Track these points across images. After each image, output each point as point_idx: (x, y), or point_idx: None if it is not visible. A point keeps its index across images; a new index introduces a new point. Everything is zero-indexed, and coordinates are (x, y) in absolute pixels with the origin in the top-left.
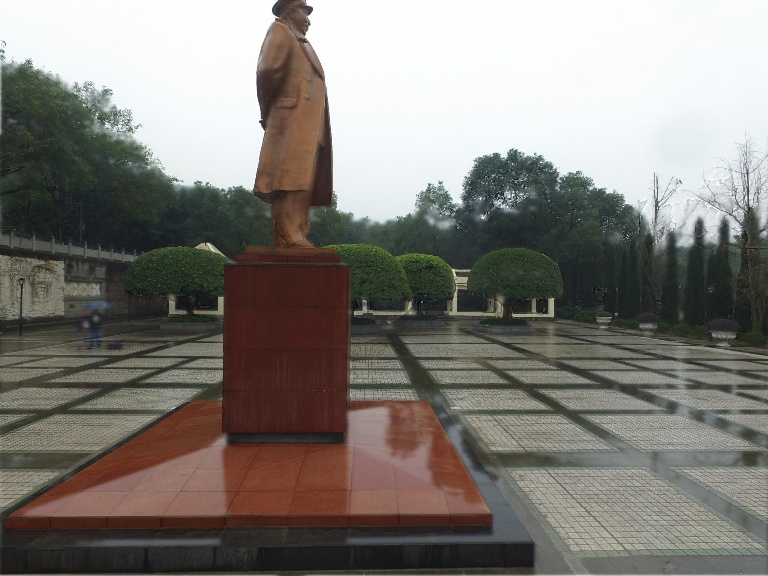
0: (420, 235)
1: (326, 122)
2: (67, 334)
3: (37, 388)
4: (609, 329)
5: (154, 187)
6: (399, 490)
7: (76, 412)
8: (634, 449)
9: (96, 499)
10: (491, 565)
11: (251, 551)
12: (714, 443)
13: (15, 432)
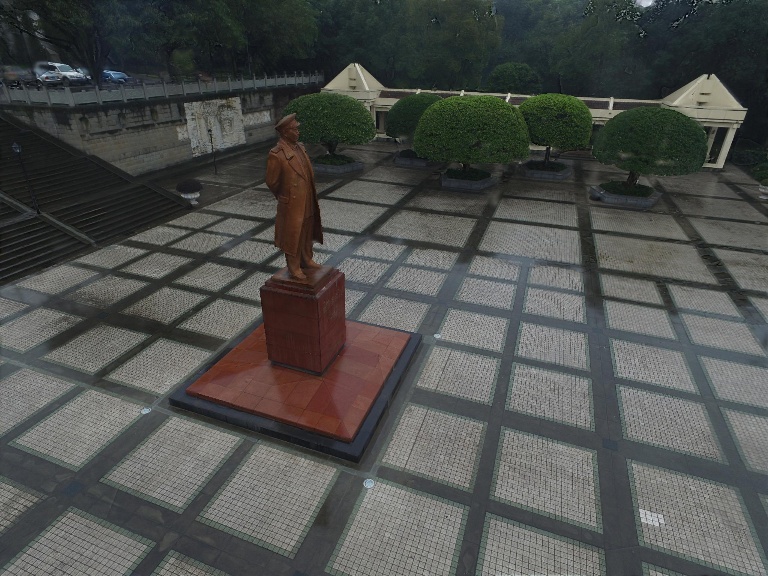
0: (583, 51)
1: (315, 197)
2: (245, 173)
3: (215, 264)
4: (767, 203)
5: (299, 26)
6: (324, 415)
7: (228, 298)
8: (502, 406)
9: (214, 388)
10: (341, 458)
11: (258, 427)
12: (565, 414)
13: (199, 314)
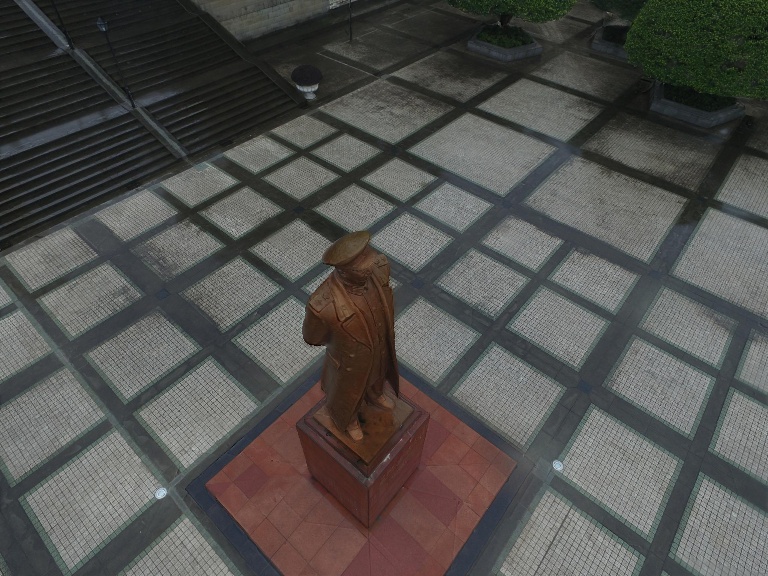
0: None
1: (391, 356)
2: (385, 45)
3: (304, 225)
4: None
5: None
6: None
7: (303, 298)
8: None
9: (236, 496)
10: None
11: None
12: None
13: (263, 321)
